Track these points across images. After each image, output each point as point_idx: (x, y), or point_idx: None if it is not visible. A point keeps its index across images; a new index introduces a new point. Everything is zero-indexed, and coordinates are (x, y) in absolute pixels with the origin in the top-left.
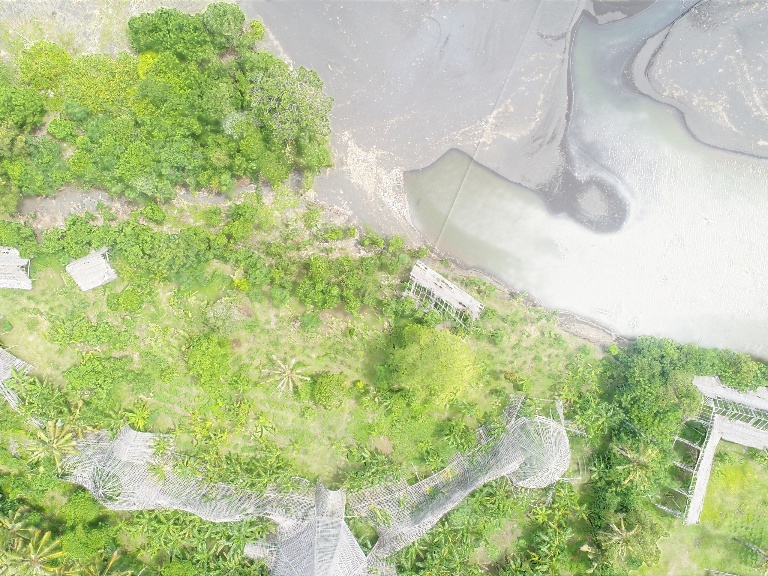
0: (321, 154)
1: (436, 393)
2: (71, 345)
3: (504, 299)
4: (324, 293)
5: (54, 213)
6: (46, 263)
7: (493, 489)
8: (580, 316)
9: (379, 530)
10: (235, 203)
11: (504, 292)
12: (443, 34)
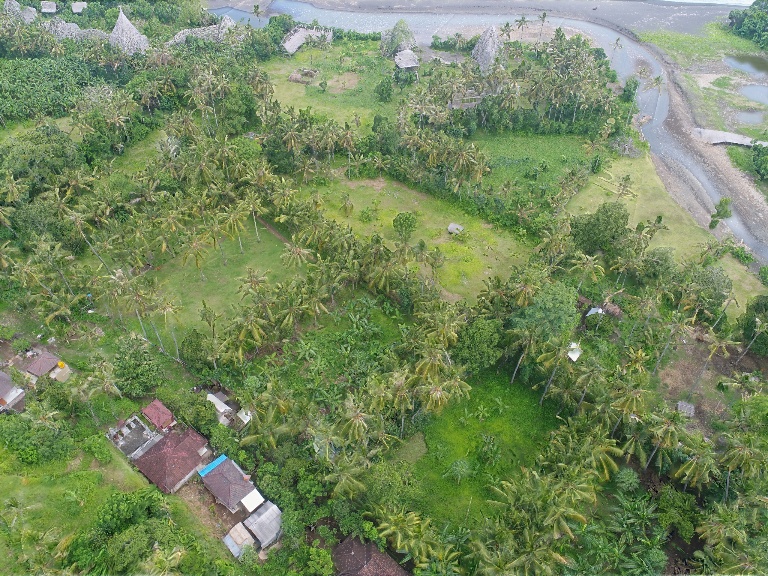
0: None
1: None
2: None
3: None
4: None
5: None
6: None
7: None
8: None
9: None
10: None
11: None
12: None
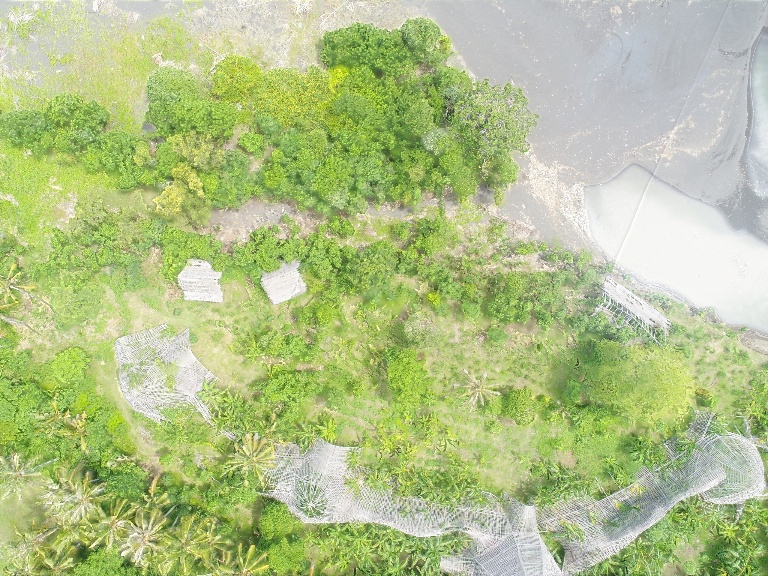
0: (512, 169)
1: (649, 410)
2: (256, 358)
3: (687, 315)
4: (517, 308)
5: (237, 226)
6: (232, 276)
7: (685, 505)
8: (760, 332)
9: (567, 545)
10: (419, 217)
11: (685, 308)
12: (625, 50)
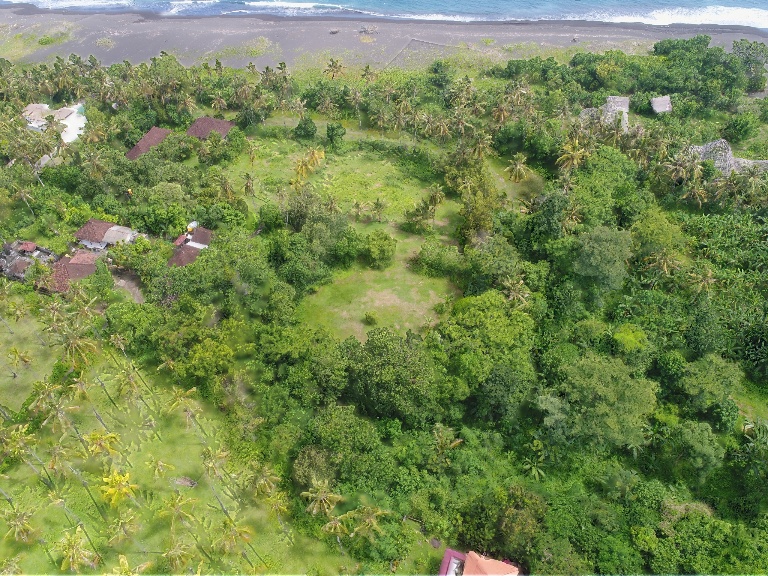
0: (764, 77)
1: None
2: None
3: None
4: None
5: None
6: None
7: None
8: None
9: None
10: None
11: None
12: None
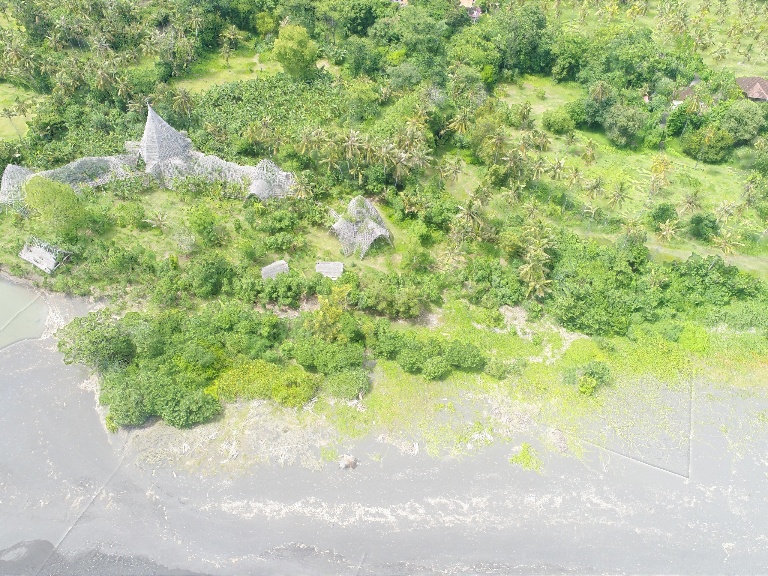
0: None
1: None
2: None
3: (5, 264)
4: None
5: None
6: None
7: None
8: None
9: None
10: None
11: (4, 271)
12: None
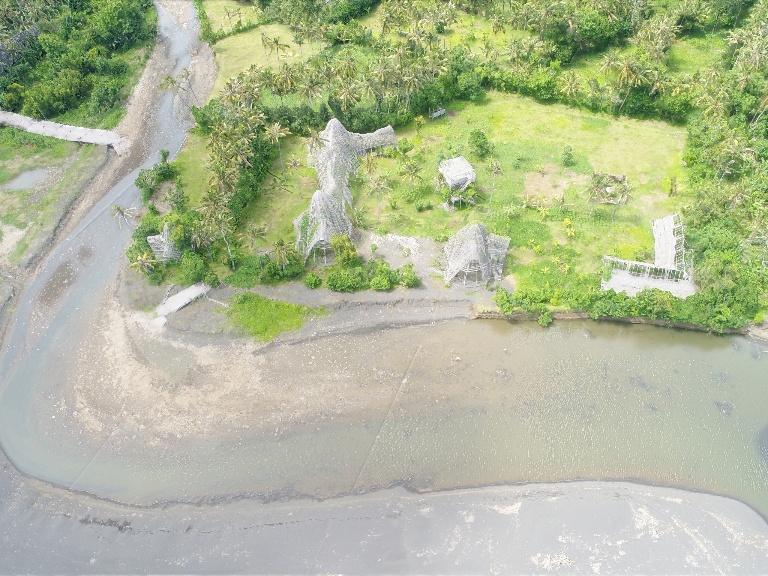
0: None
1: None
2: None
3: None
4: None
5: None
6: None
7: None
8: None
9: None
10: None
11: None
12: None
